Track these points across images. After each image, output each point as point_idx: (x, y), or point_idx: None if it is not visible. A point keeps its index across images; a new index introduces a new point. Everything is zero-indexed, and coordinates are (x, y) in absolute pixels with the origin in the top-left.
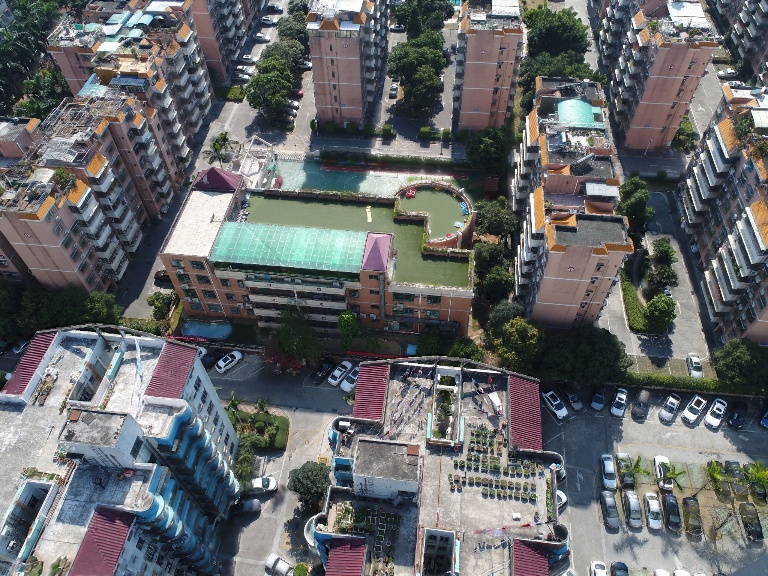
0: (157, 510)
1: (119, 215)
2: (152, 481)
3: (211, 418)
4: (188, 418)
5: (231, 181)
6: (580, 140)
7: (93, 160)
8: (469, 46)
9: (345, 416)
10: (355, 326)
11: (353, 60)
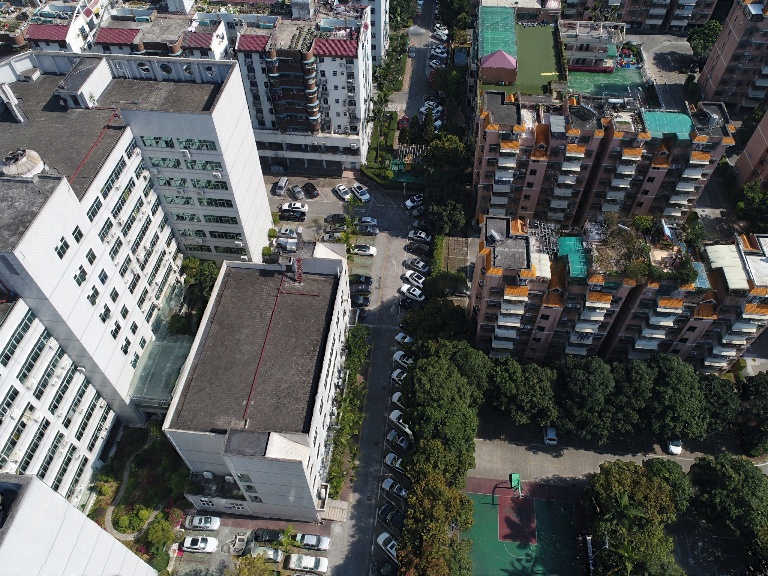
0: None
1: None
2: None
3: None
4: None
5: (551, 3)
6: (625, 118)
7: None
8: None
9: None
10: (453, 85)
11: (736, 40)
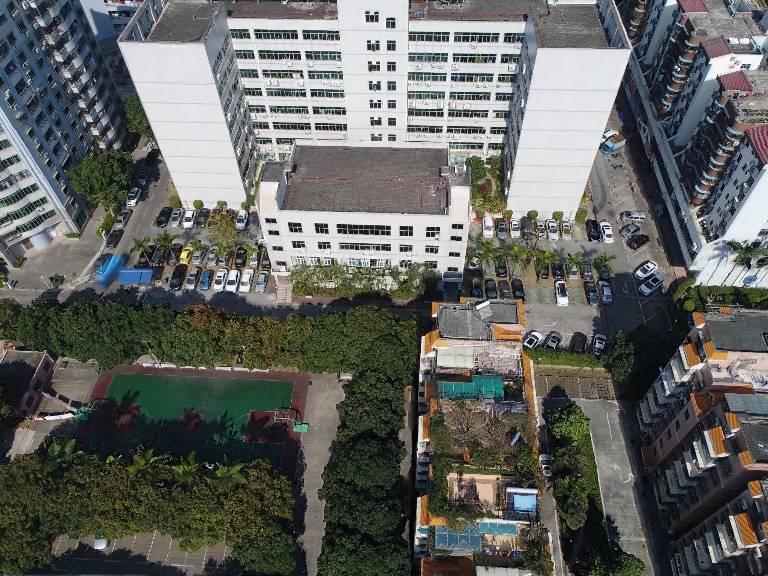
0: None
1: None
2: None
3: None
4: None
5: None
6: None
7: None
8: None
9: None
10: None
11: None
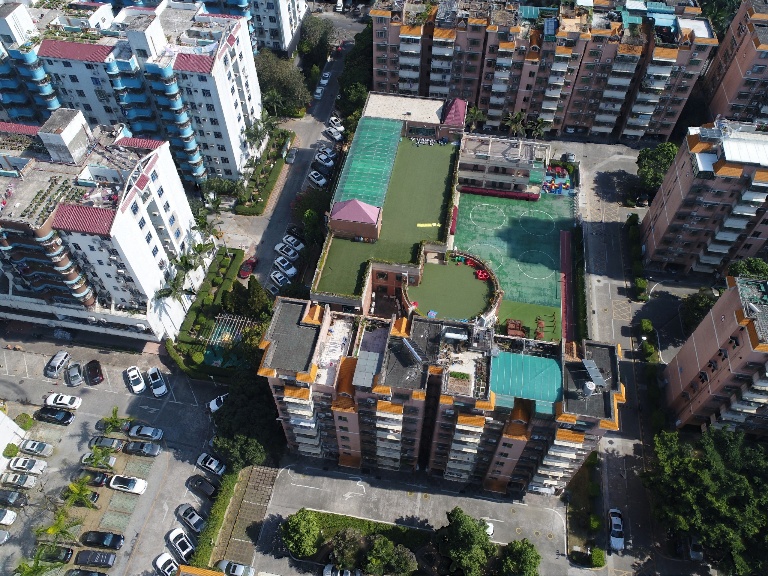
0: (110, 71)
1: (433, 79)
2: (122, 63)
3: (213, 127)
4: (162, 76)
5: (451, 118)
6: (466, 366)
7: (446, 30)
8: (723, 296)
9: (124, 129)
10: (308, 227)
11: (681, 195)
